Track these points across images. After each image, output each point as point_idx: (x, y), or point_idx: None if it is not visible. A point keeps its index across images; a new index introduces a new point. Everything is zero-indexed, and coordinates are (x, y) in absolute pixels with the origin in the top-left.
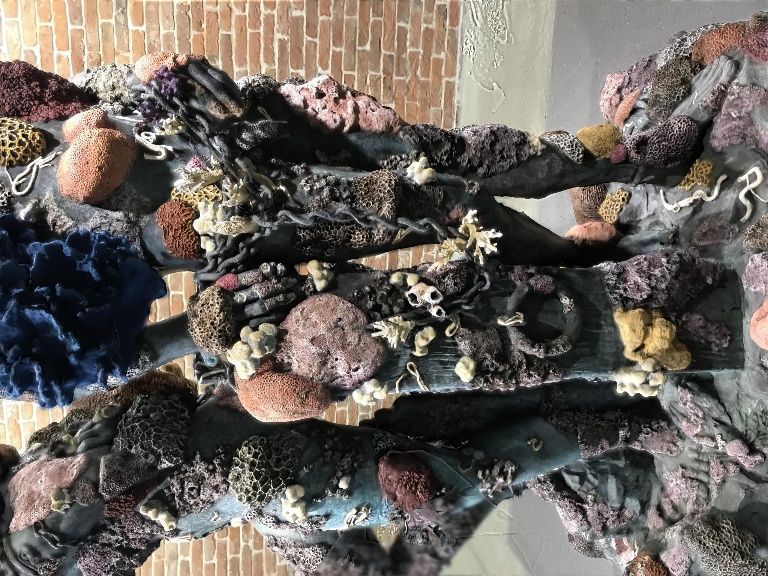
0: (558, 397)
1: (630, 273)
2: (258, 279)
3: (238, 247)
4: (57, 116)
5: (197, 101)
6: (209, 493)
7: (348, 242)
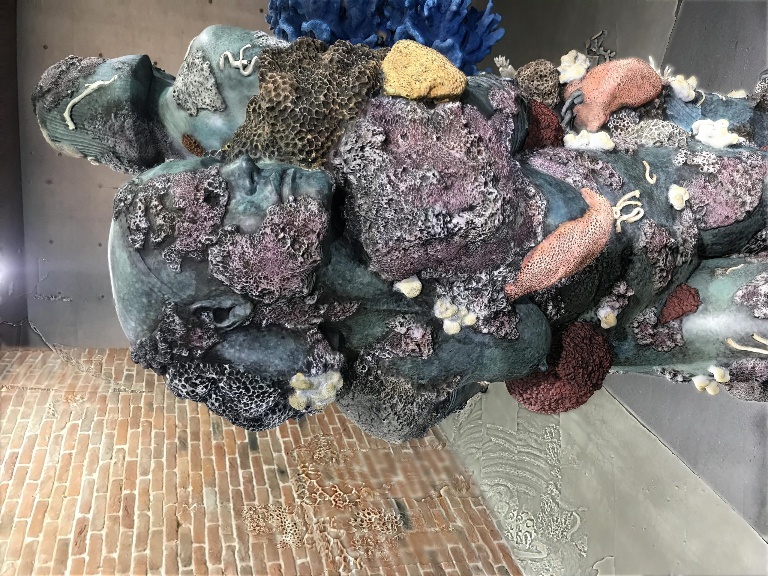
0: None
1: None
2: None
3: None
4: None
5: None
6: None
7: None
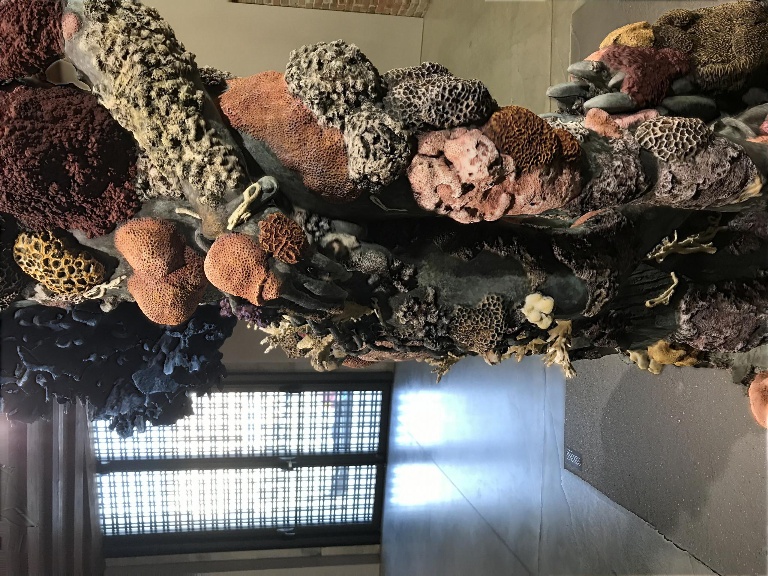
0: None
1: (700, 341)
2: None
3: None
4: (103, 234)
5: None
6: None
7: None
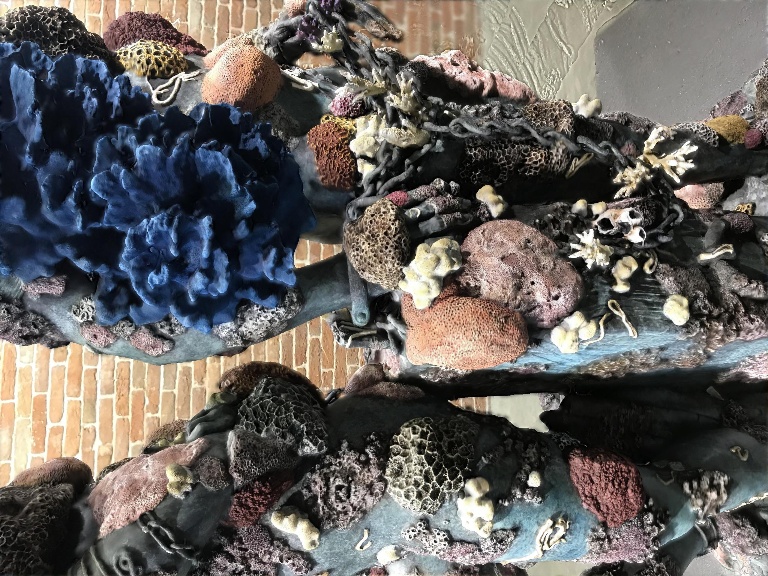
0: (739, 412)
1: None
2: (432, 192)
3: (403, 164)
4: (196, 50)
5: (354, 22)
6: (362, 494)
7: (522, 167)
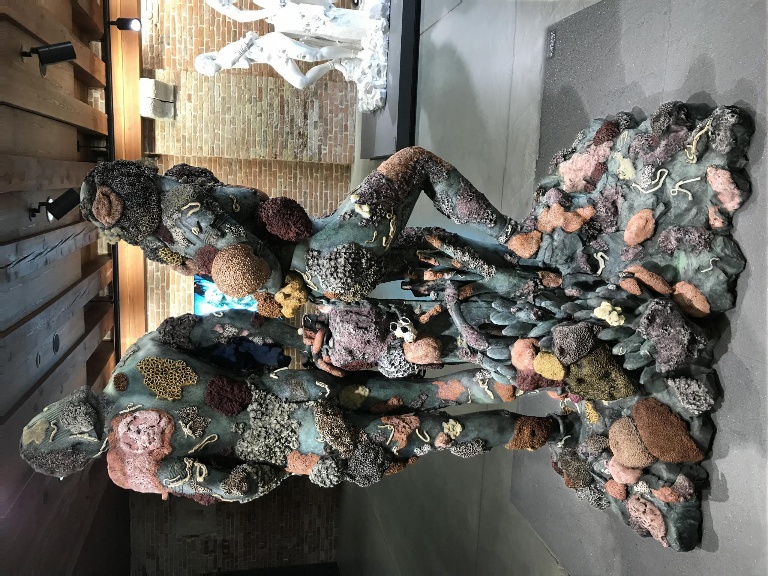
0: None
1: None
2: None
3: None
4: None
5: None
6: None
7: None
